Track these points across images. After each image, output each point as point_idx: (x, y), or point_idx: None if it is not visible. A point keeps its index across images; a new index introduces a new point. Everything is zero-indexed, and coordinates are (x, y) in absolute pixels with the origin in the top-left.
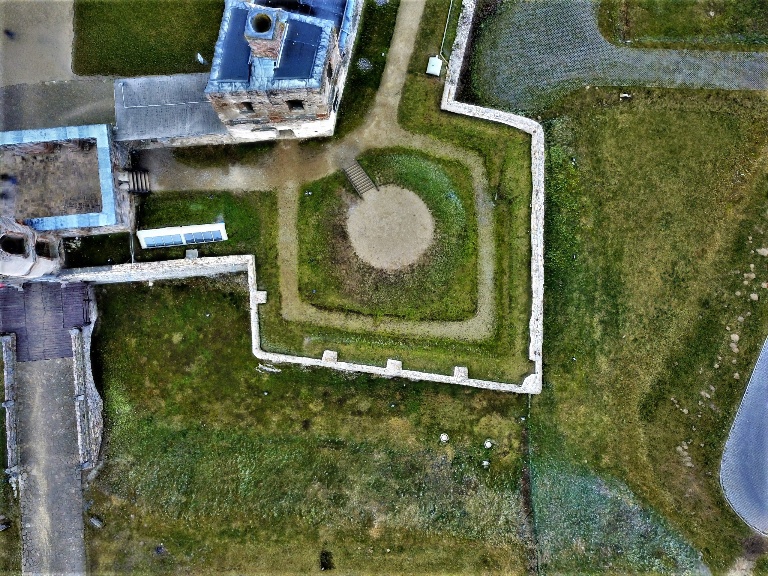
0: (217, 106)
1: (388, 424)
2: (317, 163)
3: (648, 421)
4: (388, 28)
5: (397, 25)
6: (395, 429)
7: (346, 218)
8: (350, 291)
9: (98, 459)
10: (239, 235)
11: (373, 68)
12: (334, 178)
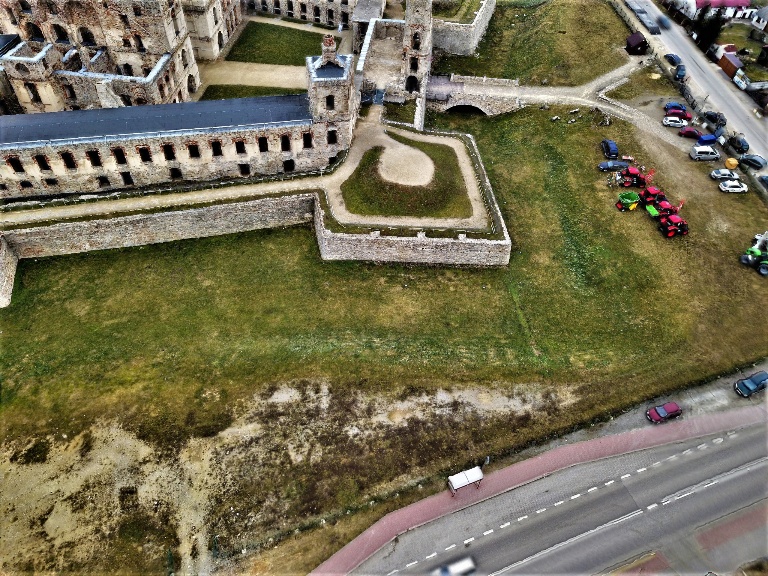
0: None
1: (506, 35)
2: (396, 7)
3: None
4: None
5: None
6: (508, 34)
7: None
8: (450, 6)
9: None
10: None
11: None
12: None
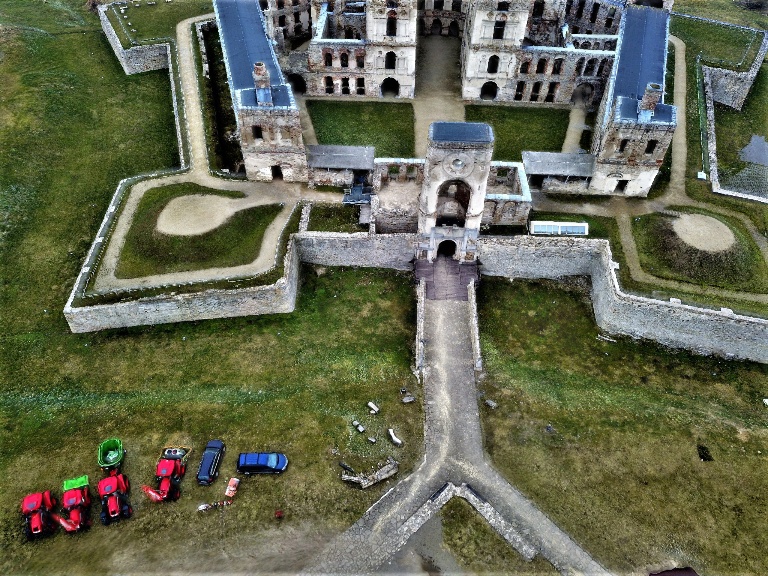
0: (610, 139)
1: (714, 387)
2: (639, 208)
3: None
4: (668, 160)
5: (673, 159)
6: (721, 391)
7: (671, 225)
8: (680, 268)
9: (482, 371)
10: (596, 233)
11: (663, 174)
12: (653, 215)
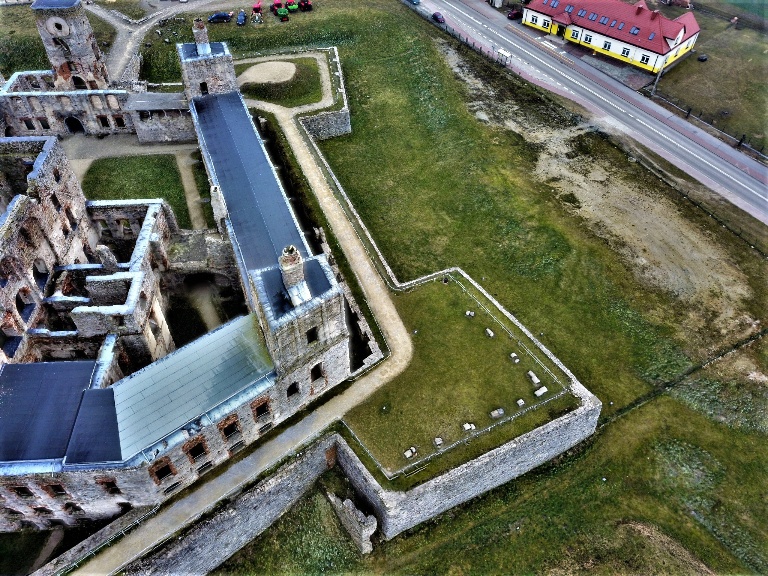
0: None
1: None
2: None
3: None
4: None
5: None
6: None
7: None
8: None
9: None
10: None
11: None
12: None
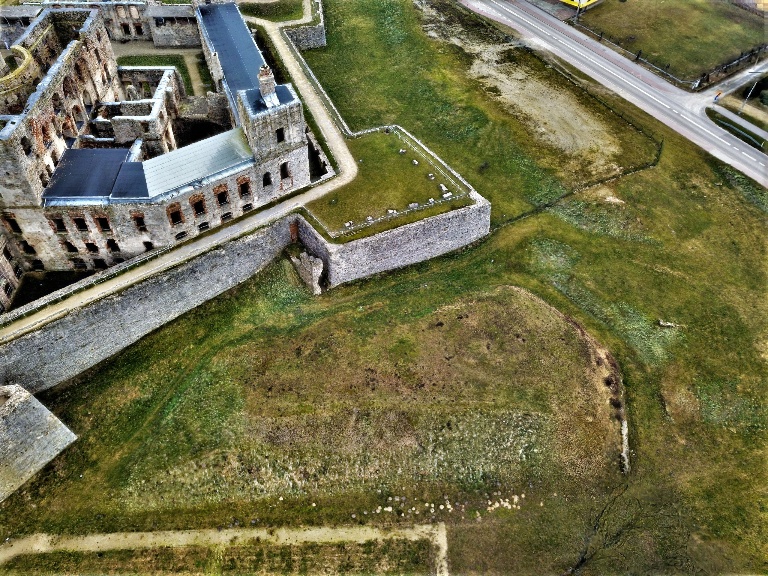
0: None
1: None
2: None
3: None
4: None
5: None
6: None
7: None
8: None
9: None
10: None
11: None
12: None
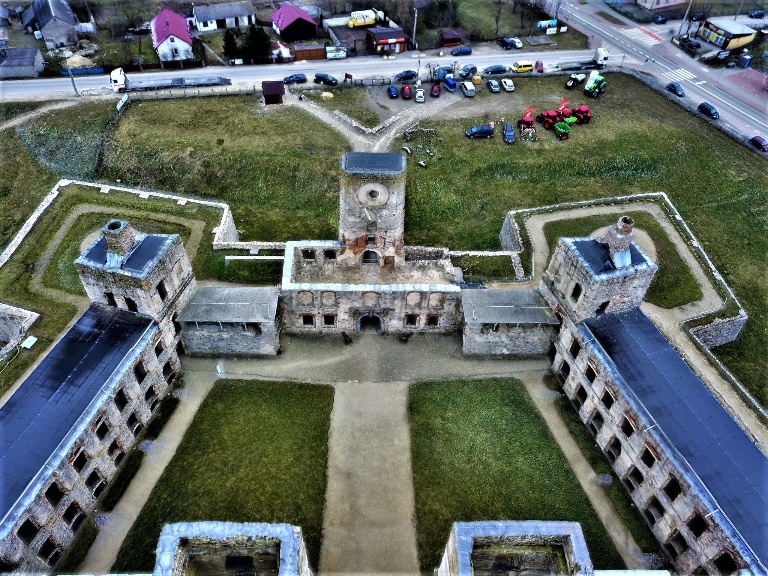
0: None
1: None
2: None
3: (8, 188)
4: None
5: None
6: None
7: None
8: None
9: None
10: None
11: None
12: None
